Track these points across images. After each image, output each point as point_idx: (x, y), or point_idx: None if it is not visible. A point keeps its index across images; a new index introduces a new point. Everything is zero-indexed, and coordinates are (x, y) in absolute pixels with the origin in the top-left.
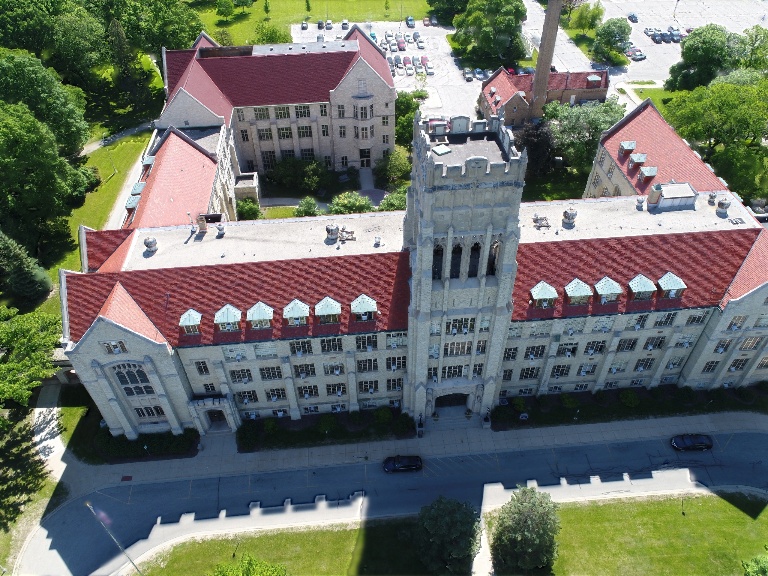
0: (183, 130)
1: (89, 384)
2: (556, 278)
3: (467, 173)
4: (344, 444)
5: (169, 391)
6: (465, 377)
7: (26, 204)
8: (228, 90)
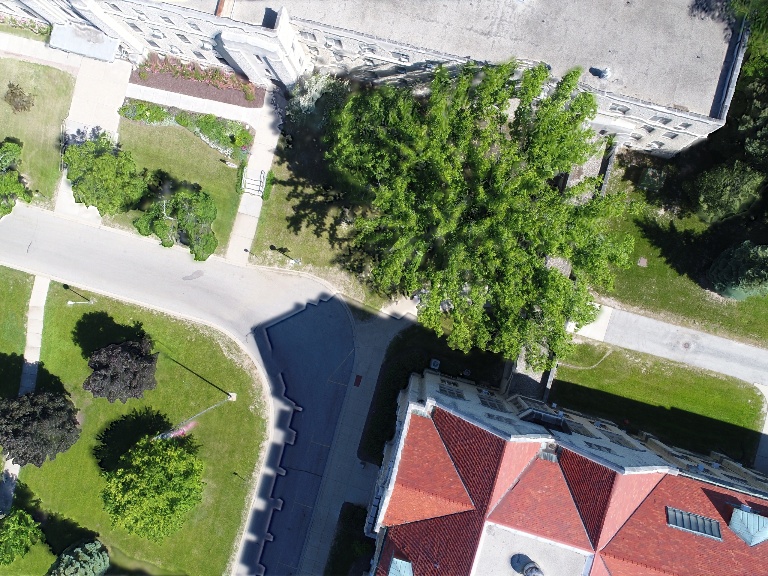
0: None
1: None
2: None
3: None
4: None
5: None
6: None
7: None
8: None
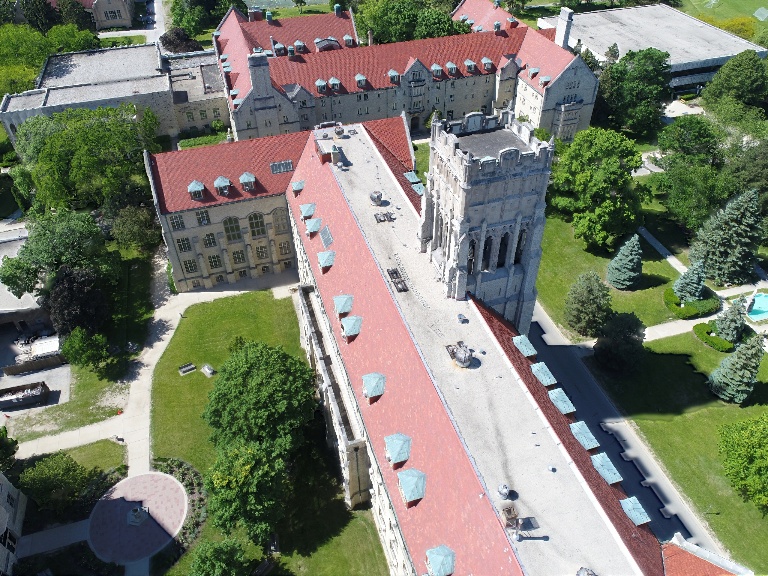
0: None
1: None
2: None
3: None
4: None
5: None
6: None
7: None
8: None
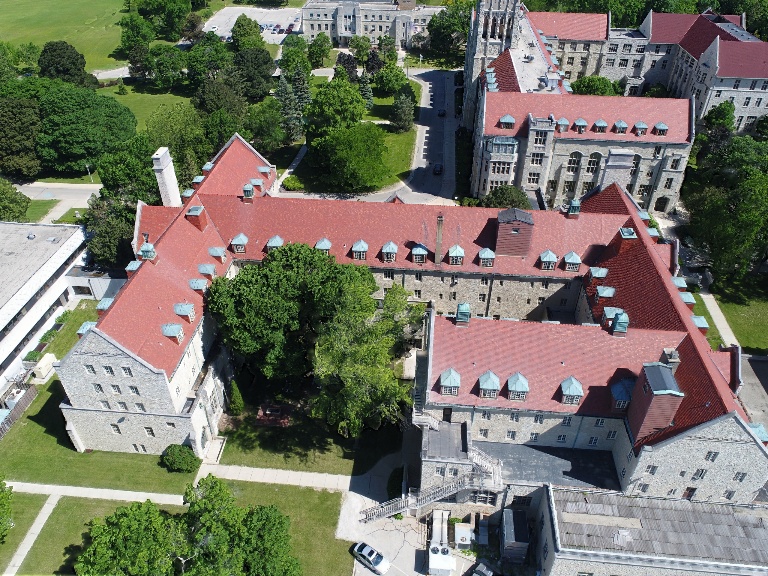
0: None
1: None
2: None
3: None
4: None
5: None
6: None
7: None
8: None
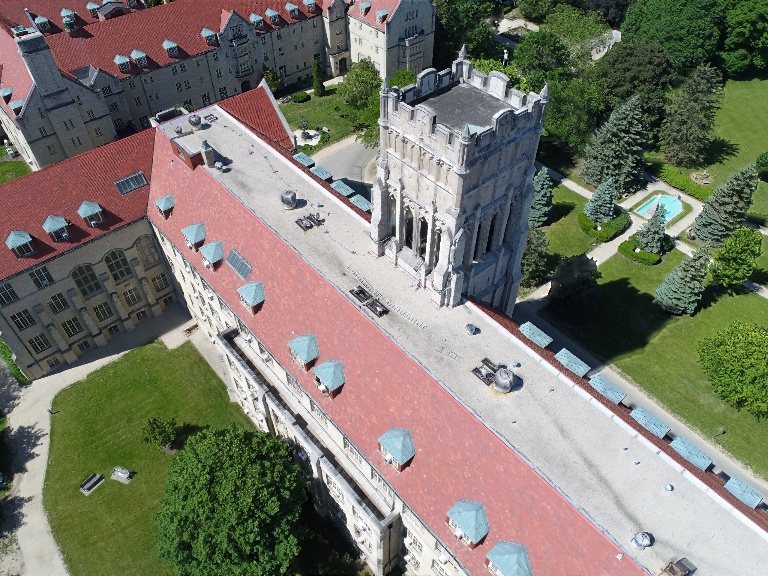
0: None
1: None
2: None
3: None
4: None
5: None
6: None
7: None
8: None
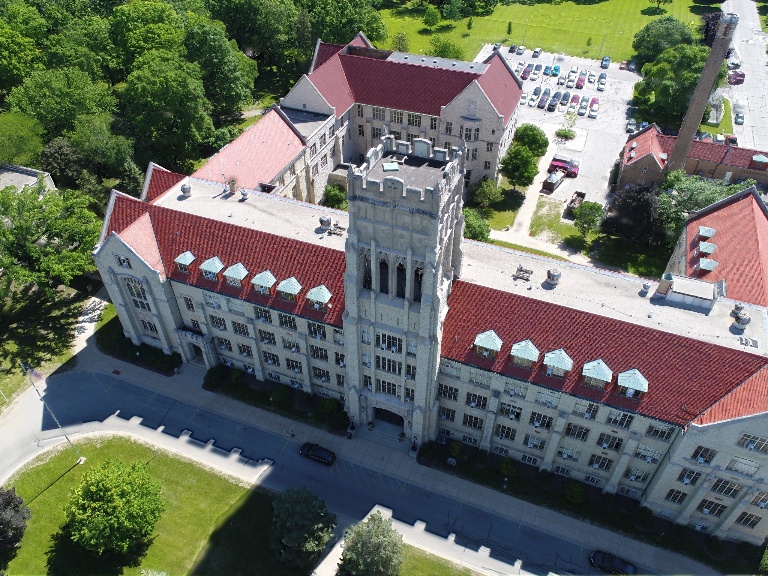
0: (301, 112)
1: (108, 286)
2: (507, 332)
3: (385, 191)
4: (283, 416)
5: (162, 314)
6: (399, 398)
7: (163, 142)
8: (355, 86)
